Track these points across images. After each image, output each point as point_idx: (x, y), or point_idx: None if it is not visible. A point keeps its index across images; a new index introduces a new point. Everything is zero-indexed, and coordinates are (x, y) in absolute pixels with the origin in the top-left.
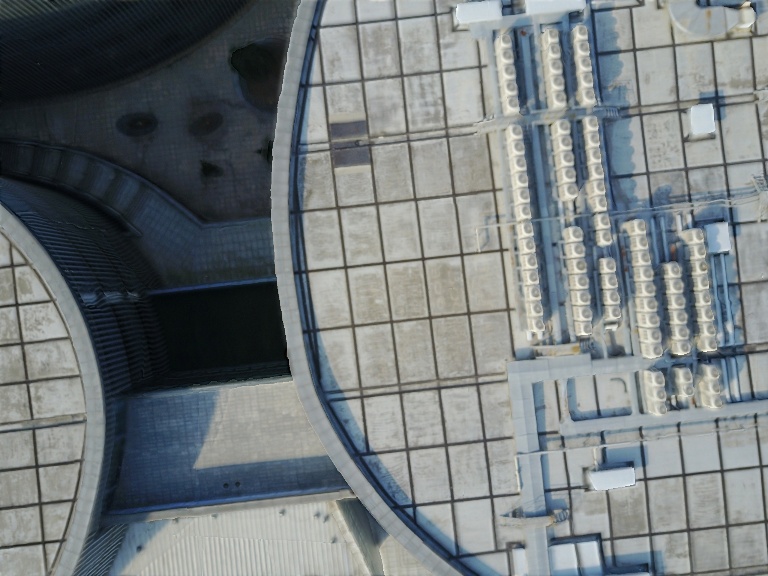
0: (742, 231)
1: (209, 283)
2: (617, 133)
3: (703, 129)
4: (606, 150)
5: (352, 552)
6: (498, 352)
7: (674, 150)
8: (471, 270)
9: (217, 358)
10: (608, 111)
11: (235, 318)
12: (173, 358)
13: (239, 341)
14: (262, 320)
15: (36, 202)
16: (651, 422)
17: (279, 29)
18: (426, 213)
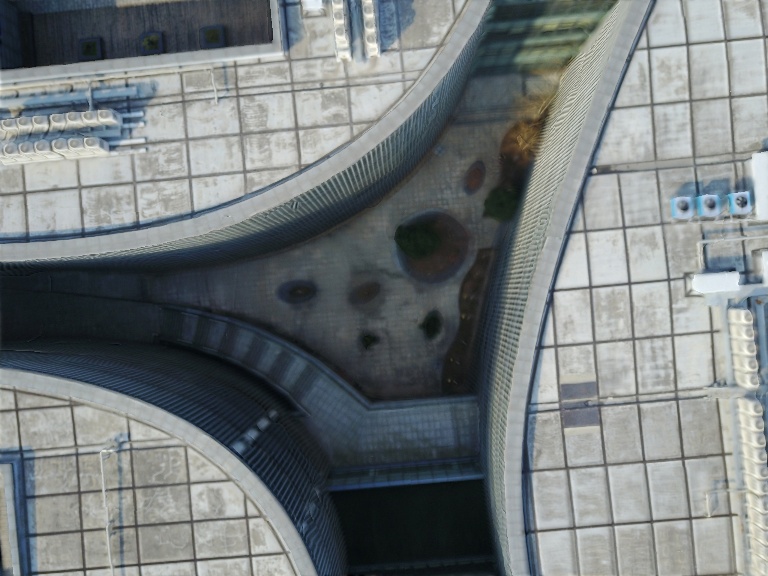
0: None
1: (375, 464)
2: None
3: None
4: None
5: None
6: None
7: None
8: (700, 534)
9: (394, 553)
10: None
11: (413, 514)
12: (351, 553)
13: (415, 536)
14: (439, 517)
15: (240, 419)
16: None
17: (437, 201)
18: (655, 476)
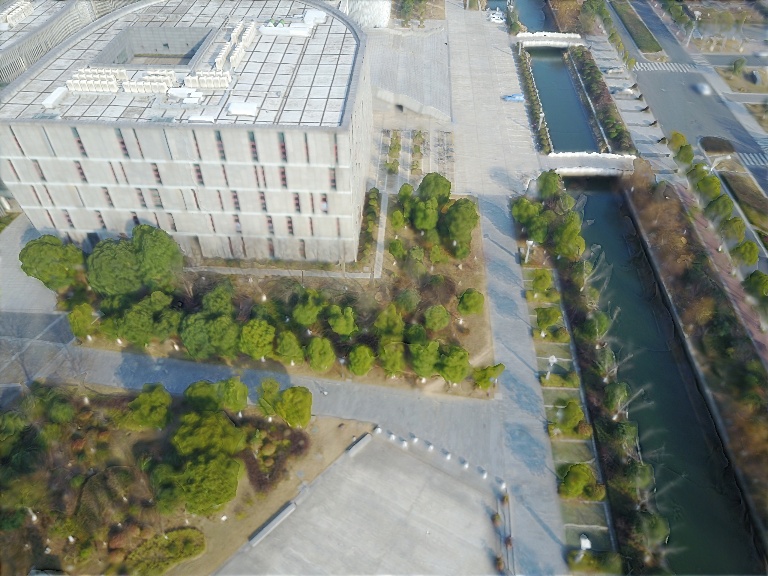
0: None
1: None
2: None
3: None
4: None
5: (327, 2)
6: None
7: None
8: None
9: None
10: None
11: None
12: None
13: None
14: None
15: None
16: None
17: None
18: None
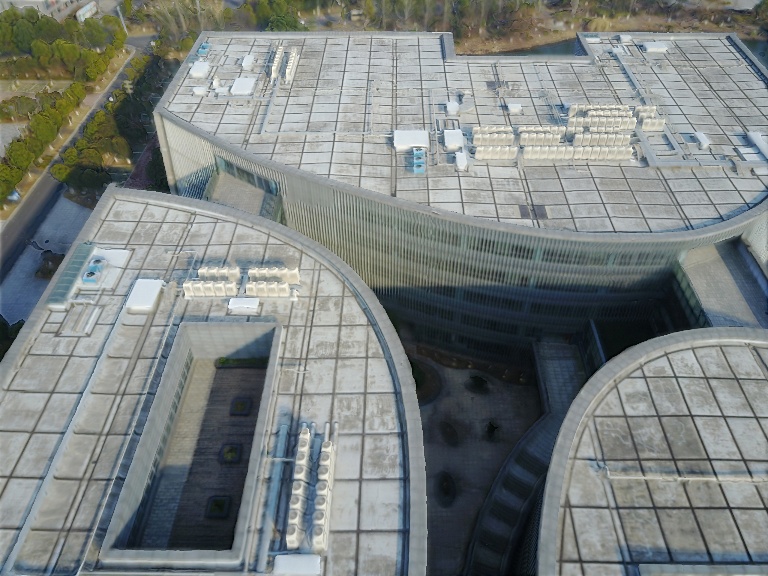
0: None
1: None
2: None
3: (520, 106)
4: None
5: None
6: None
7: (528, 117)
8: None
9: None
10: None
11: None
12: None
13: None
14: None
15: None
16: (667, 129)
17: None
18: (571, 188)
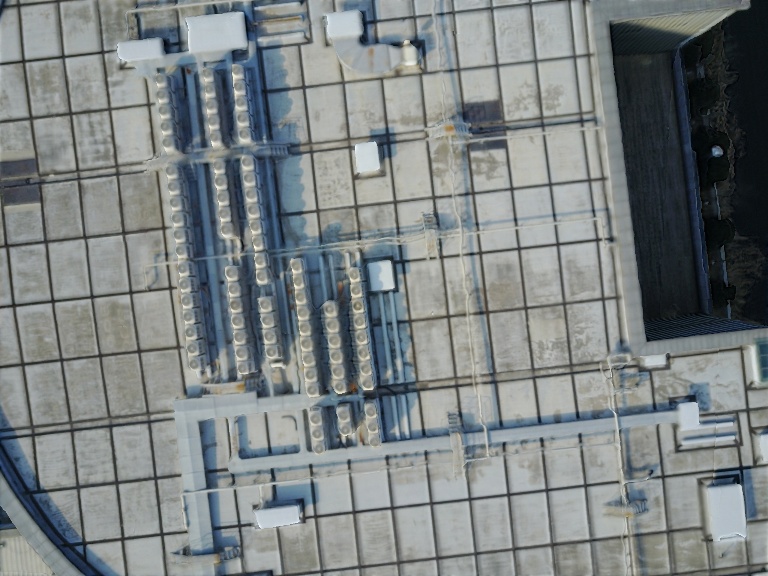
0: (412, 269)
1: None
2: (288, 171)
3: (367, 167)
4: (276, 188)
5: None
6: (169, 390)
7: (344, 187)
8: (140, 308)
9: None
10: (273, 149)
11: None
12: None
13: None
14: None
15: None
16: (319, 460)
17: None
18: (95, 251)
